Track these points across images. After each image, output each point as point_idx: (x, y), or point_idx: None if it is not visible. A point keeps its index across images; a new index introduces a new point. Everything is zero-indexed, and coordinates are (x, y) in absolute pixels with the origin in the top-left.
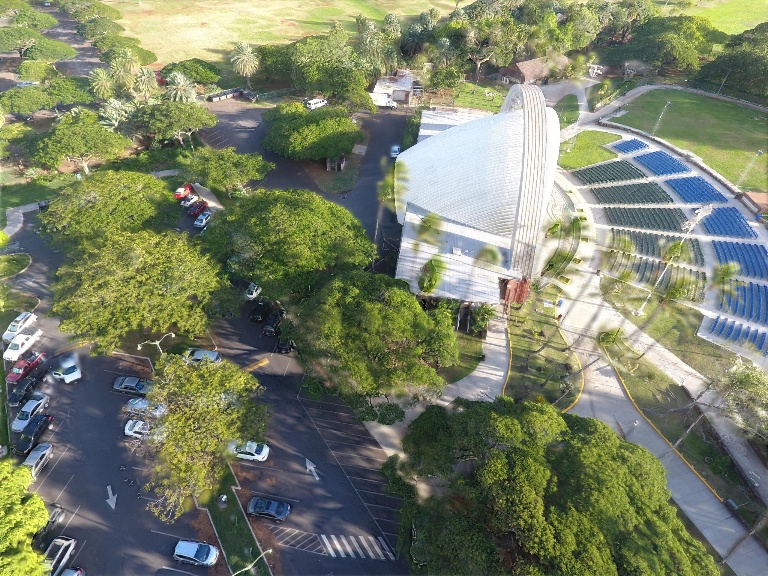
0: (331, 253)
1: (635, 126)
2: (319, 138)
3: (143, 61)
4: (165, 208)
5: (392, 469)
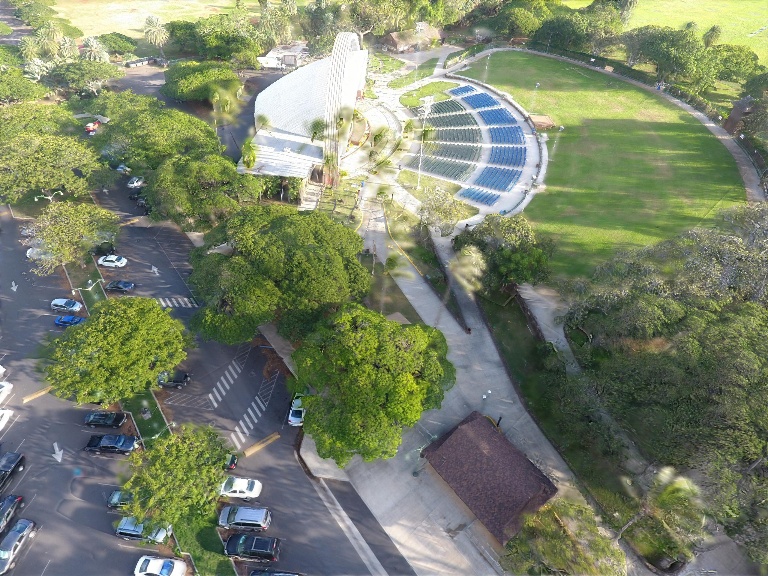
0: (182, 143)
1: (473, 77)
2: (203, 83)
3: (70, 36)
4: (70, 128)
5: (195, 251)
